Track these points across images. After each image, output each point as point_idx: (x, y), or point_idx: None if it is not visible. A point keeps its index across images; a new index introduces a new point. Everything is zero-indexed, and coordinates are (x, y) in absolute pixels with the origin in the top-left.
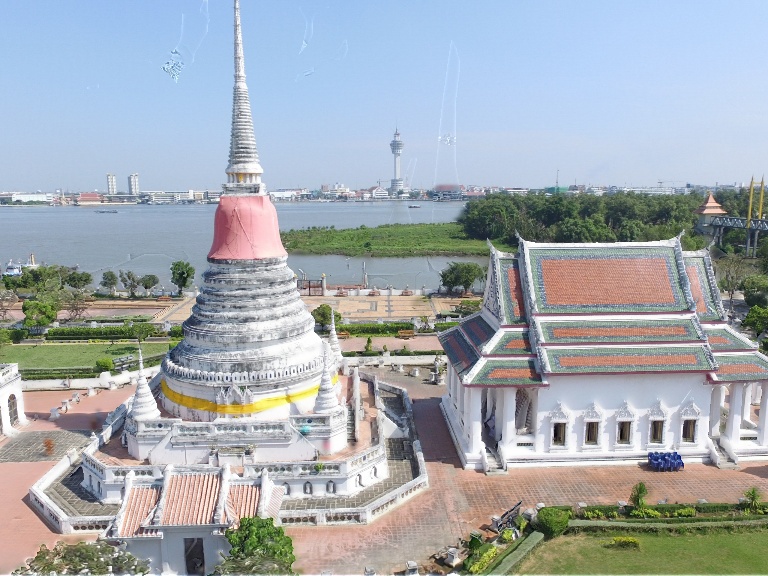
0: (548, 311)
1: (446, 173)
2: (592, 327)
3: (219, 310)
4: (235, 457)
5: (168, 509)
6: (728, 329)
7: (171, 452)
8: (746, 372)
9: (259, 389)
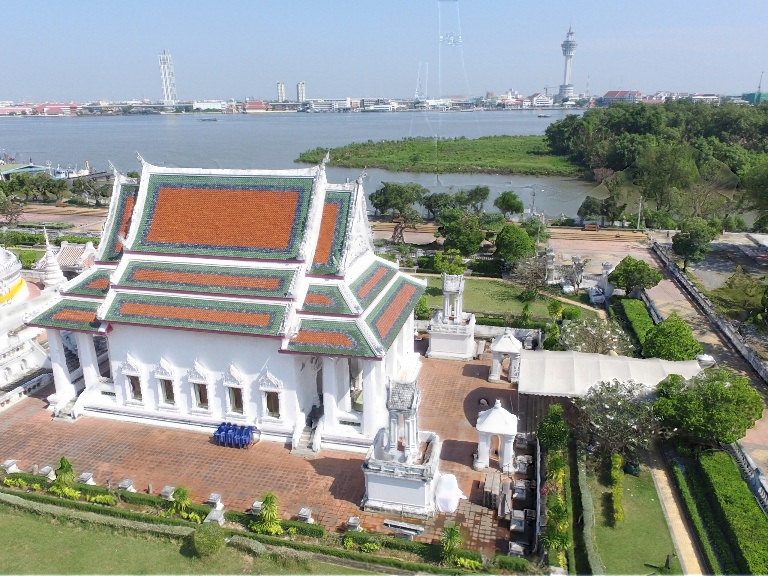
0: (141, 248)
1: (453, 79)
2: (179, 271)
3: None
4: None
5: None
6: (340, 287)
7: None
8: (327, 343)
9: None
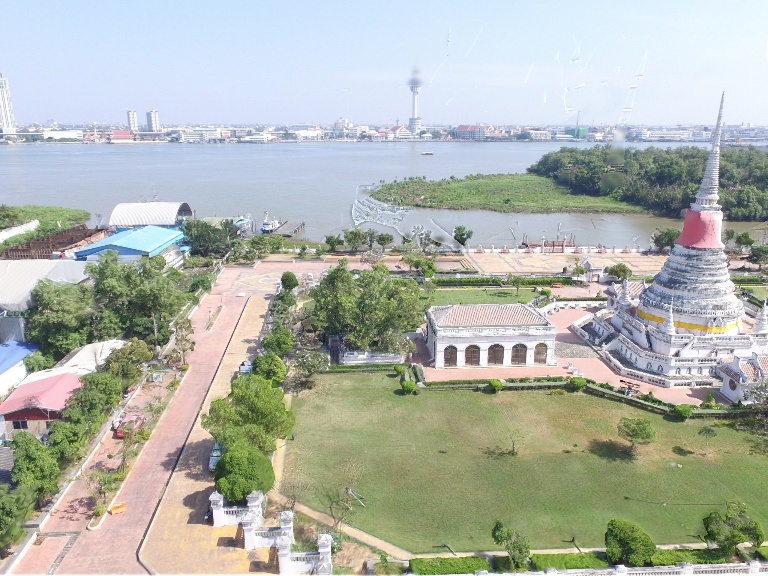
0: None
1: (617, 150)
2: None
3: (700, 276)
4: (726, 354)
5: (765, 371)
6: None
7: (692, 351)
8: None
9: (728, 319)
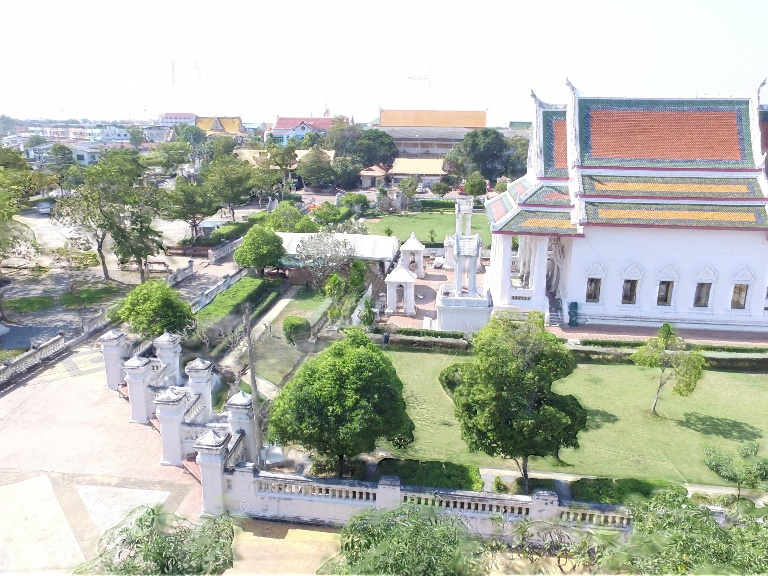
0: None
1: None
2: None
3: None
4: None
5: None
6: None
7: None
8: None
9: None
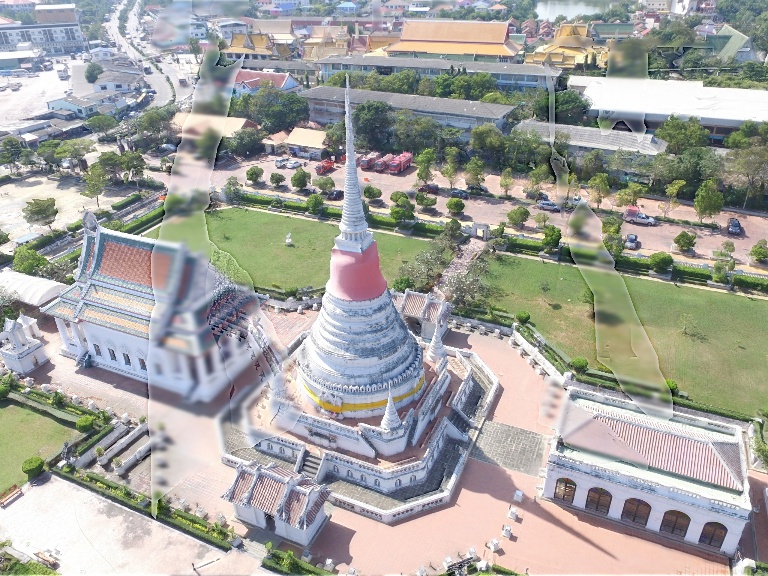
0: None
1: None
2: None
3: None
4: None
5: None
6: None
7: None
8: None
9: None
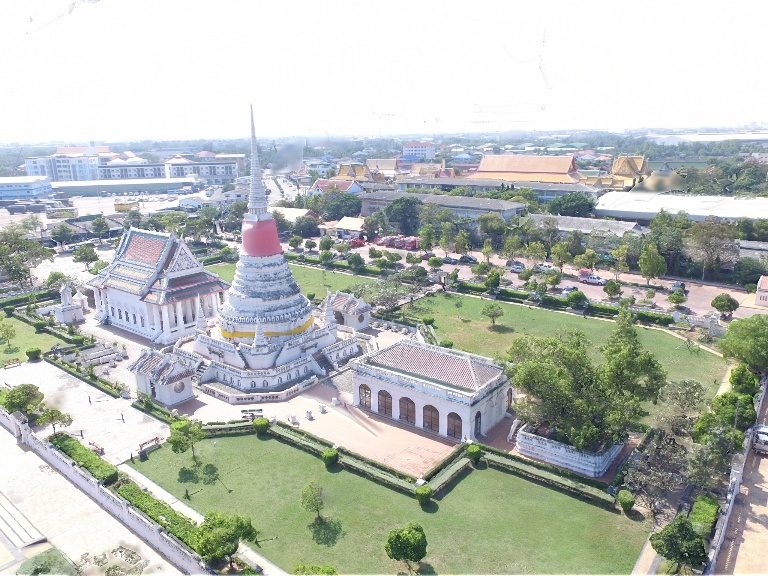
0: None
1: None
2: None
3: None
4: None
5: None
6: None
7: None
8: None
9: None
